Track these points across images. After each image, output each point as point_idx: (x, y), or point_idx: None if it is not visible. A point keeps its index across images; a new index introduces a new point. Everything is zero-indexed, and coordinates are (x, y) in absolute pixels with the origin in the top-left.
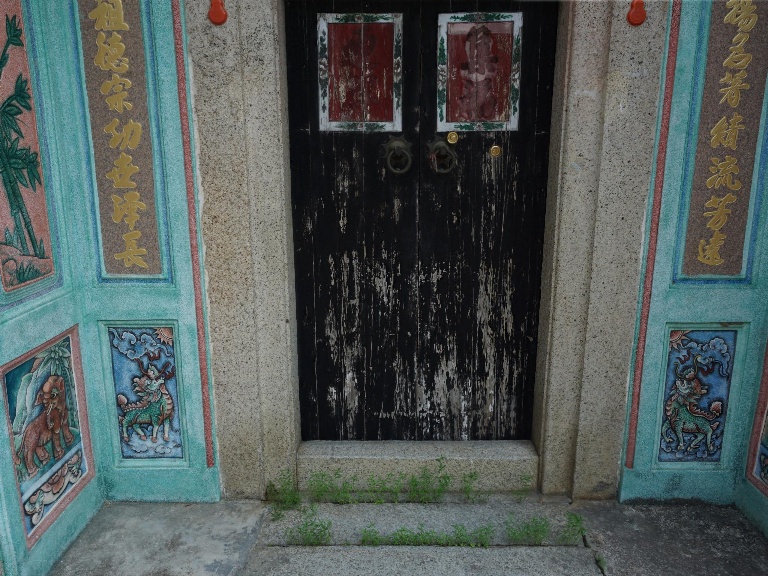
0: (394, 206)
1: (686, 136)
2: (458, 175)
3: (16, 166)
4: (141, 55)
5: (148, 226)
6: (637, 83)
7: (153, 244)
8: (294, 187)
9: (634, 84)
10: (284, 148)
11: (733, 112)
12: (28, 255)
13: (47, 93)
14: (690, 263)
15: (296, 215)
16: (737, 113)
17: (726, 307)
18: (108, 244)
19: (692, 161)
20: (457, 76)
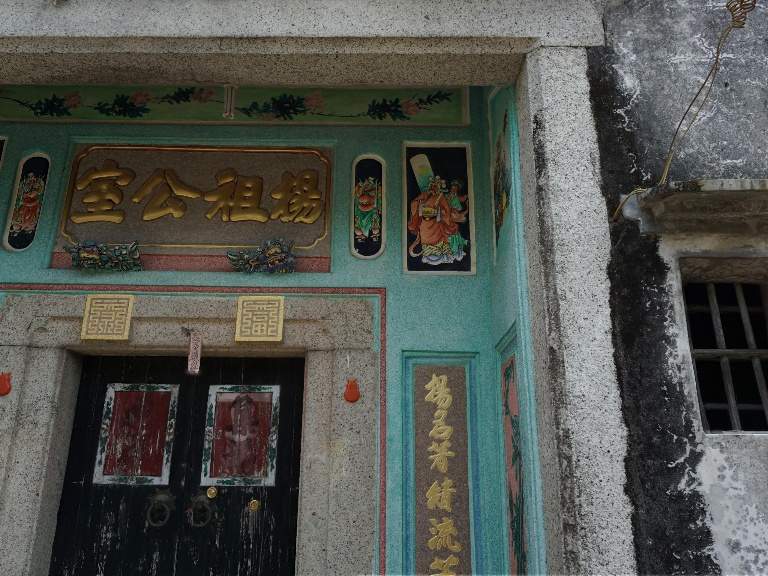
0: (153, 560)
1: (403, 498)
2: (217, 528)
3: None
4: None
5: None
6: (357, 450)
7: None
8: (58, 538)
9: (354, 450)
10: (46, 501)
11: (443, 477)
12: None
13: None
14: None
15: (54, 568)
16: (447, 478)
17: None
18: None
19: (412, 522)
20: (222, 436)
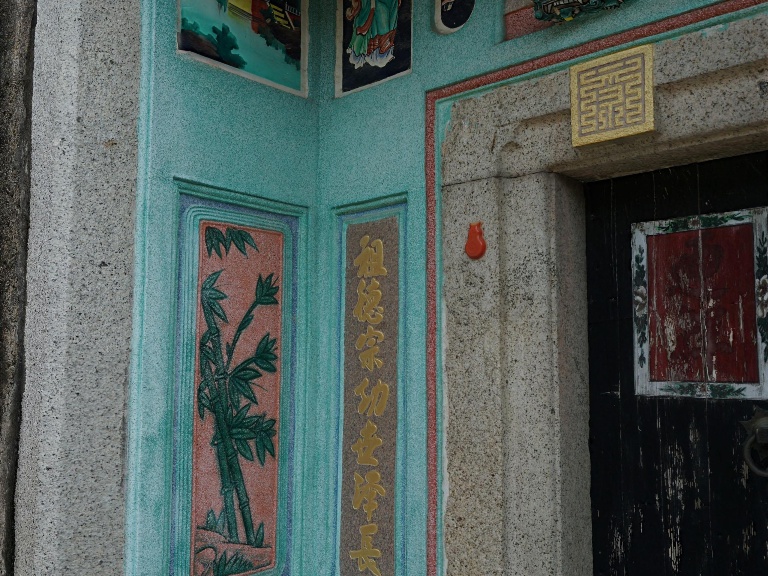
0: None
1: None
2: None
3: (240, 436)
4: (395, 302)
5: (385, 519)
6: None
7: (388, 545)
8: (596, 481)
9: None
10: (567, 422)
11: None
12: (236, 542)
13: (302, 351)
14: None
15: (598, 527)
16: None
17: None
18: (345, 536)
19: None
20: None
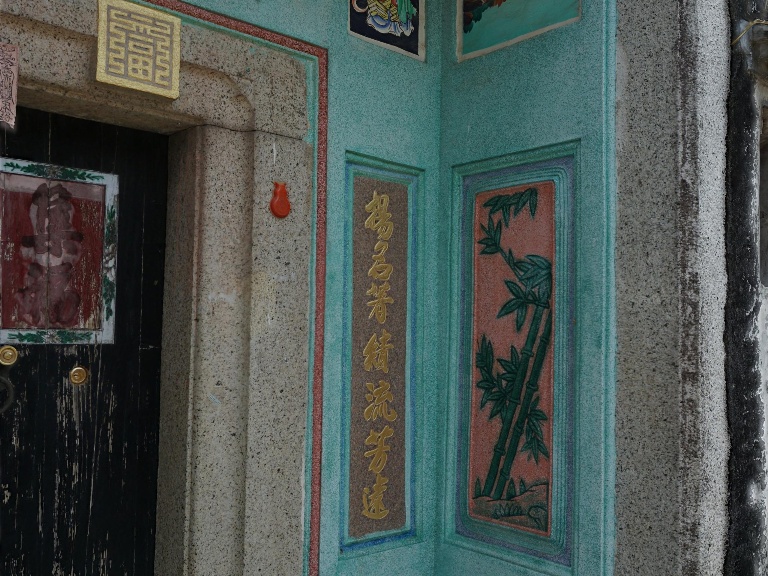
0: None
1: (341, 357)
2: (14, 418)
3: None
4: None
5: None
6: (285, 289)
7: None
8: None
9: (282, 290)
10: None
11: (382, 329)
12: None
13: None
14: (356, 521)
15: None
16: (385, 330)
17: (397, 572)
18: None
19: (349, 388)
20: (15, 255)
